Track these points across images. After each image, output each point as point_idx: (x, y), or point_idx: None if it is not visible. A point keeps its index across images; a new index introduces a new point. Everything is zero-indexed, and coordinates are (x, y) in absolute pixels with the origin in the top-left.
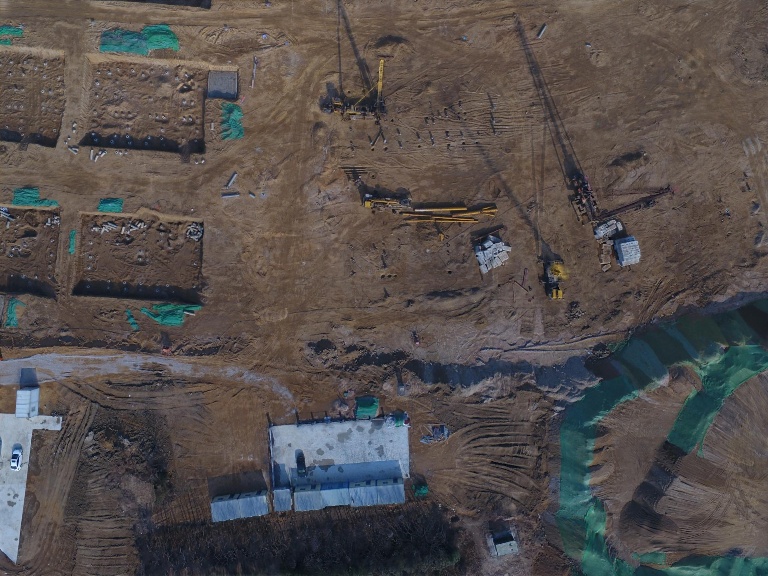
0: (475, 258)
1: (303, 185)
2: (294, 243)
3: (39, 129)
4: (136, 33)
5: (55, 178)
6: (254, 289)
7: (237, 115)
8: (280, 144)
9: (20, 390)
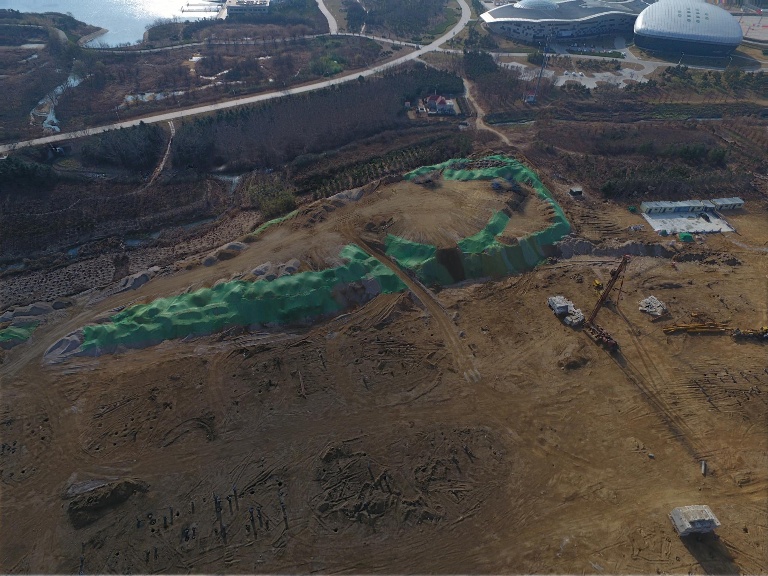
0: None
1: None
2: None
3: None
4: None
5: None
6: None
7: None
8: None
9: None
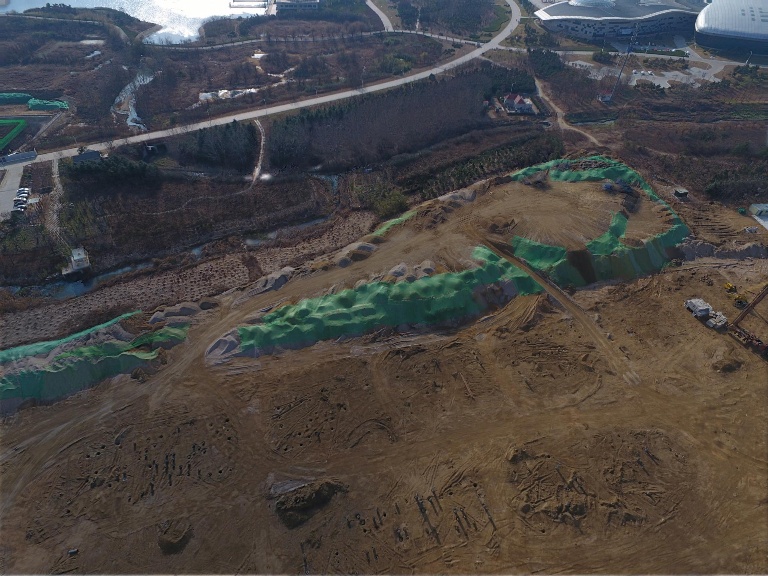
0: None
1: None
2: None
3: None
4: None
5: None
6: None
7: None
8: None
9: None
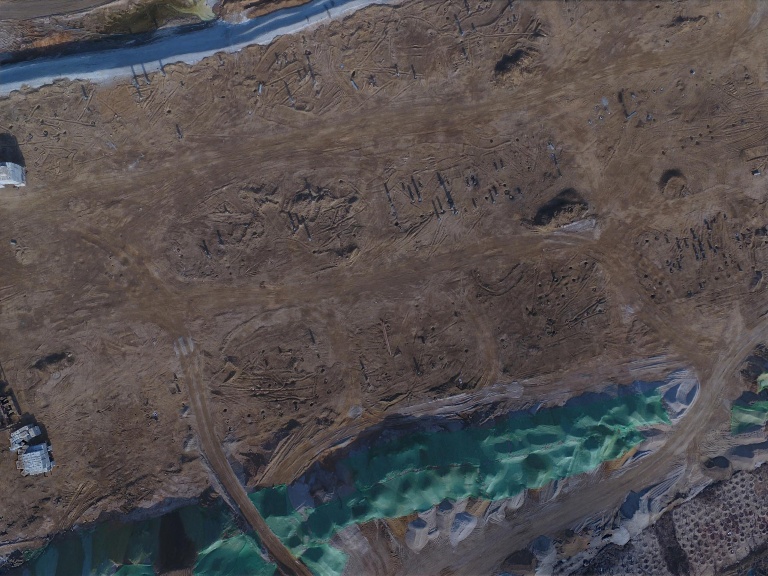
0: None
1: None
2: None
3: None
4: None
5: None
6: None
7: None
8: None
9: None
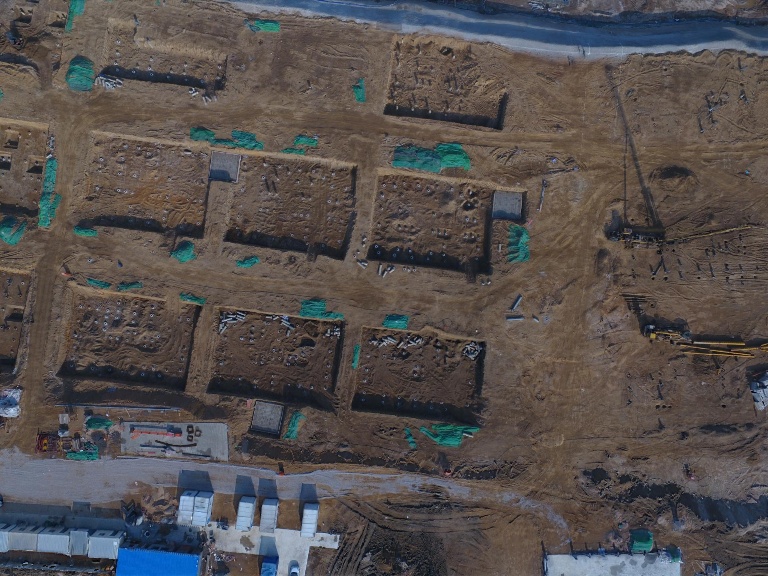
0: (750, 393)
1: (586, 311)
2: (574, 369)
3: (324, 239)
4: (429, 150)
5: (342, 291)
6: (532, 413)
7: (525, 238)
8: (564, 269)
9: (307, 509)
